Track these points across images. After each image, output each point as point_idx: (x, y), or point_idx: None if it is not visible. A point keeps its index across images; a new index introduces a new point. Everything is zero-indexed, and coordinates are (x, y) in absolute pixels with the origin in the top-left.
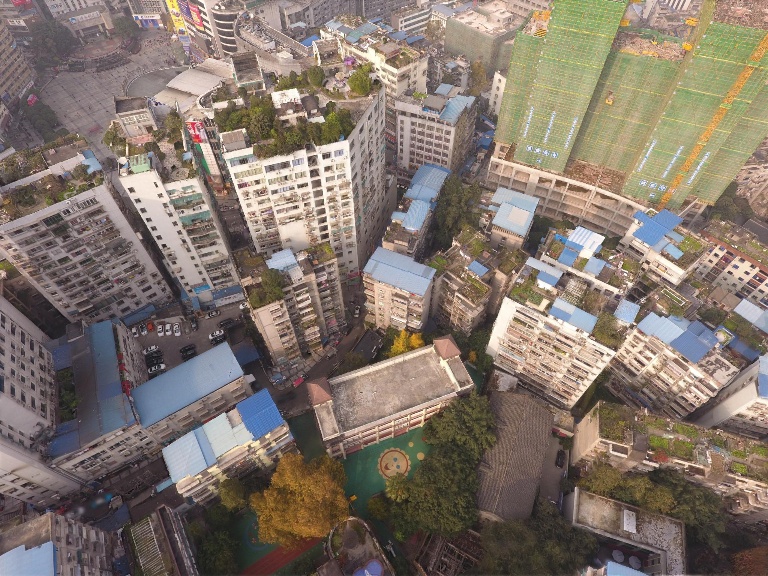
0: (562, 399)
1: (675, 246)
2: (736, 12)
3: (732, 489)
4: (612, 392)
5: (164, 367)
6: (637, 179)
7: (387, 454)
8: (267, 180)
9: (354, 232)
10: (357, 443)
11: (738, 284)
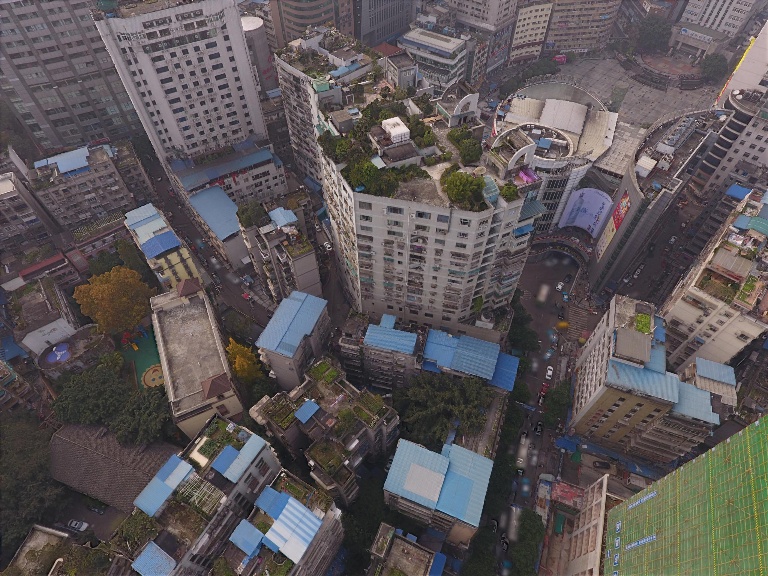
0: None
1: None
2: None
3: None
4: None
5: None
6: None
7: None
8: None
9: None
10: None
11: None
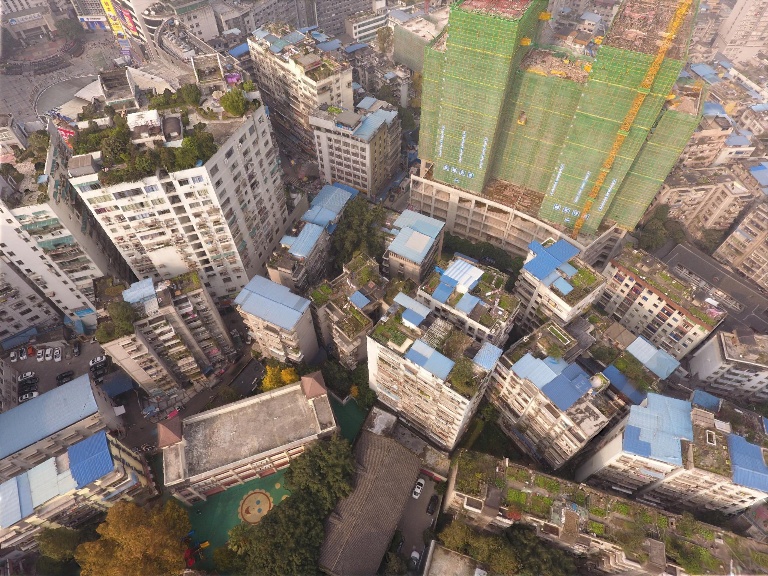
0: (441, 440)
1: (568, 280)
2: (628, 35)
3: (593, 548)
4: (504, 430)
5: (36, 395)
6: (551, 203)
7: (250, 496)
8: (120, 207)
9: (238, 257)
10: (213, 486)
11: (648, 316)
